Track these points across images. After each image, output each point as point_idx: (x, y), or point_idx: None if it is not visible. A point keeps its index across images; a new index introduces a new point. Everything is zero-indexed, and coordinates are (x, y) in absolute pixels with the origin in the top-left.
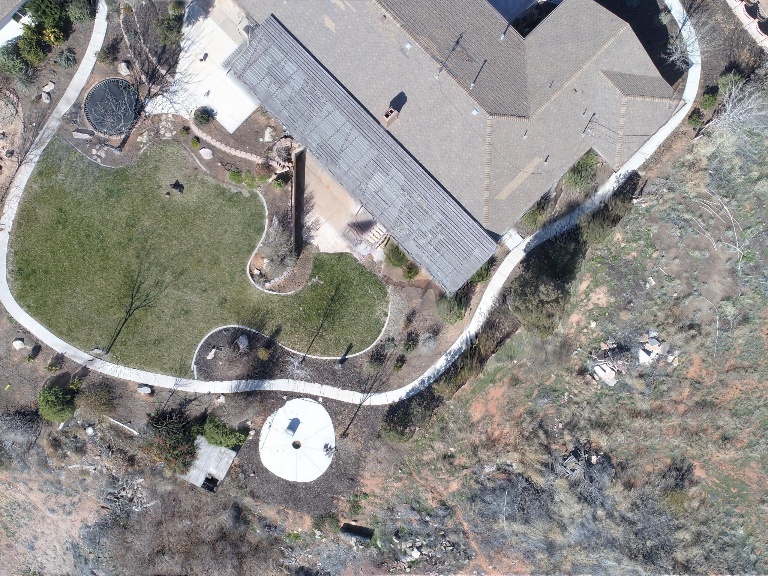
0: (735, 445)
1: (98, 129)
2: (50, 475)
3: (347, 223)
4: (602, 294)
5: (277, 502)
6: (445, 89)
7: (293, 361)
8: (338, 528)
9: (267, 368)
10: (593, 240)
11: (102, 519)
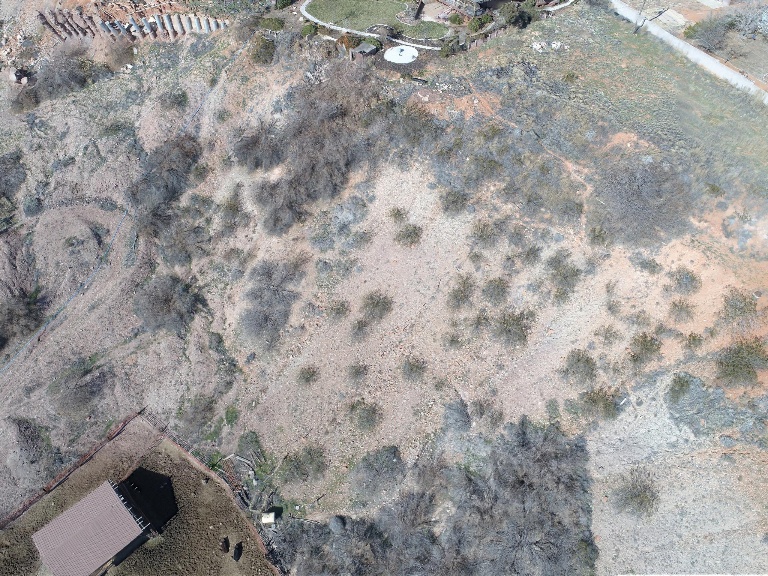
0: None
1: None
2: (287, 63)
3: None
4: (537, 33)
5: None
6: None
7: None
8: None
9: (395, 36)
10: (532, 14)
11: (299, 85)
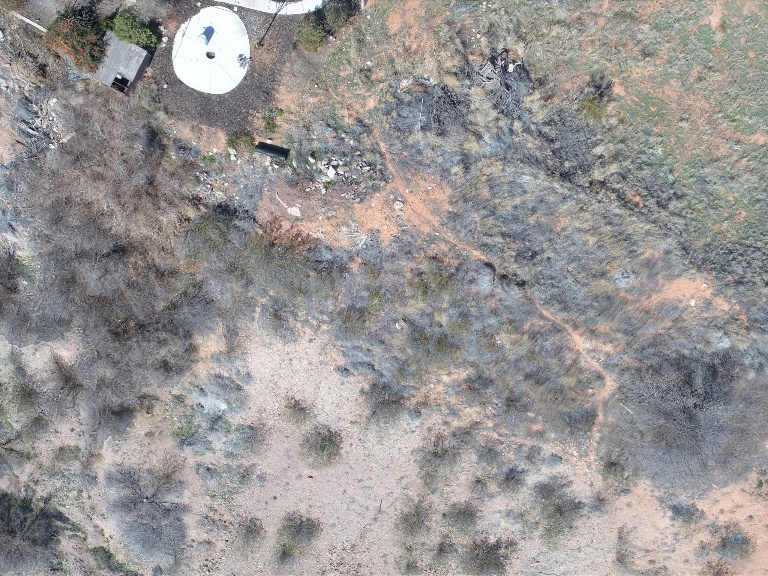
0: (654, 60)
1: None
2: None
3: None
4: None
5: (191, 117)
6: None
7: None
8: (253, 147)
9: None
10: None
11: (18, 157)
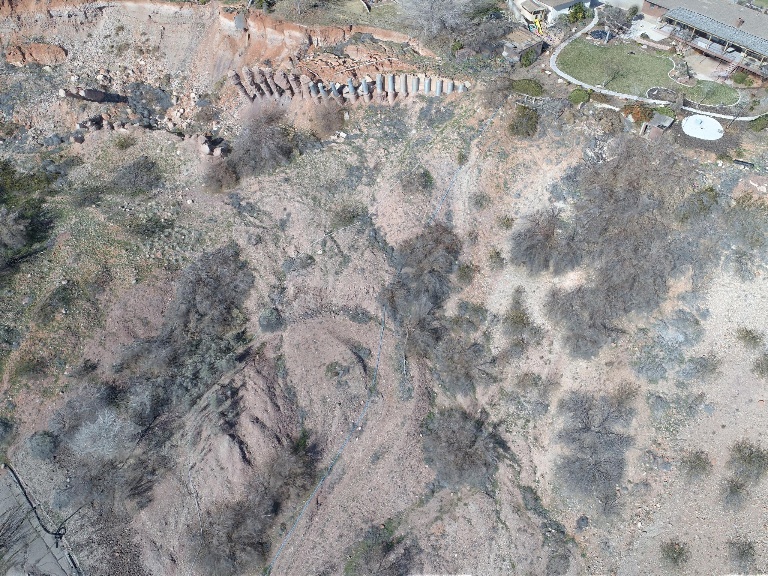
0: None
1: (596, 38)
2: (558, 137)
3: (711, 72)
4: None
5: (694, 147)
6: (761, 17)
7: (694, 104)
8: (732, 161)
9: None
10: None
11: (579, 165)
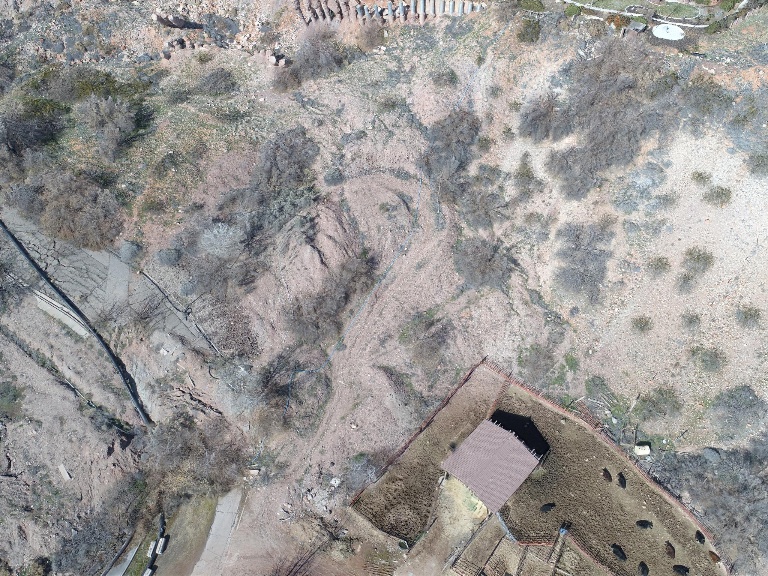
0: None
1: None
2: (556, 41)
3: None
4: None
5: None
6: None
7: (663, 17)
8: (690, 54)
9: (654, 15)
10: None
11: (573, 61)
